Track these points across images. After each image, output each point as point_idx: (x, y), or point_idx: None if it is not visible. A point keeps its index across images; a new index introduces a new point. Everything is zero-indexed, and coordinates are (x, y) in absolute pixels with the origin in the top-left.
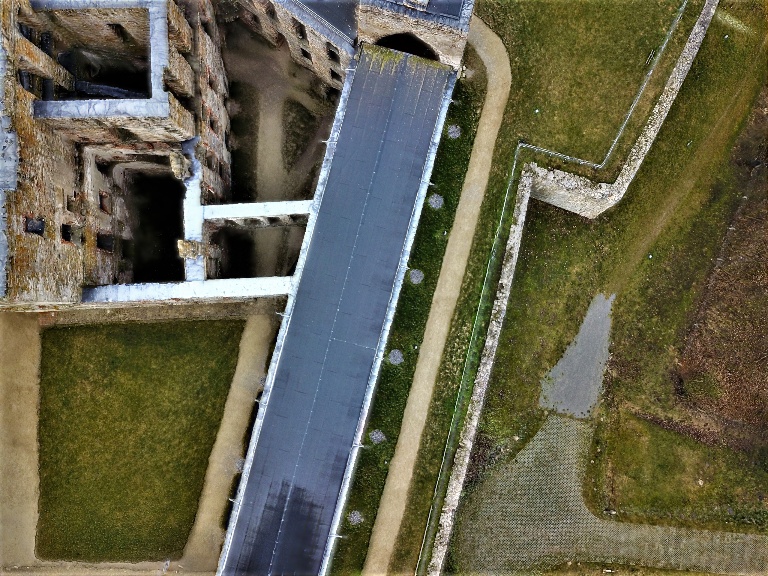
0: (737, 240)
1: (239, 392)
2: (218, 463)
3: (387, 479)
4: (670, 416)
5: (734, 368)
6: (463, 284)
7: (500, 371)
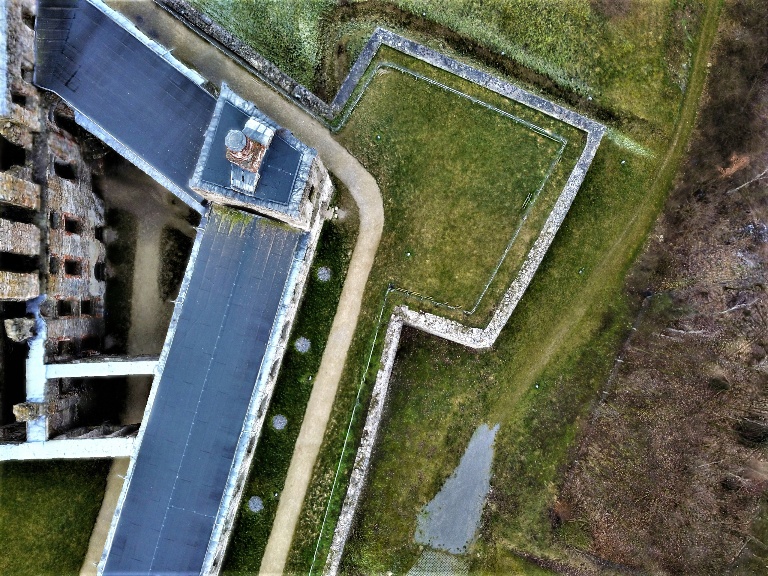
0: (624, 373)
1: (104, 527)
2: None
3: None
4: (546, 555)
5: (613, 508)
6: (327, 430)
7: (376, 504)
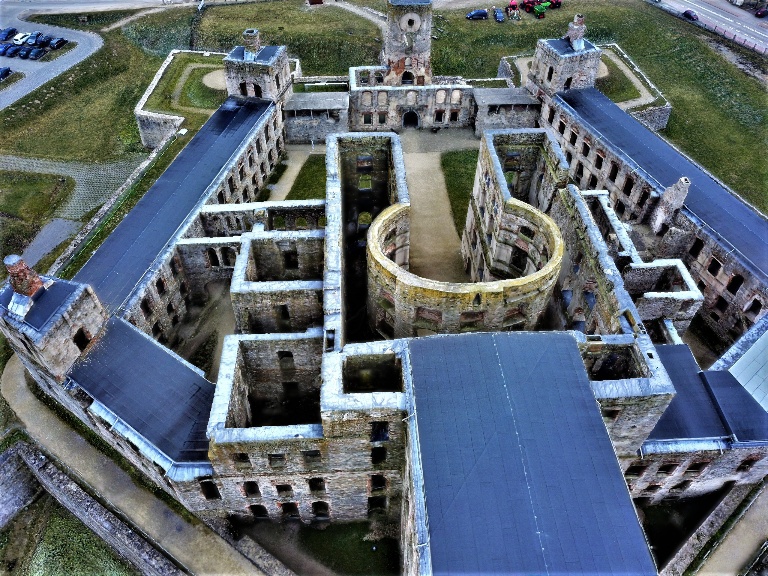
0: None
1: None
2: (286, 188)
3: None
4: (0, 217)
5: None
6: None
7: None
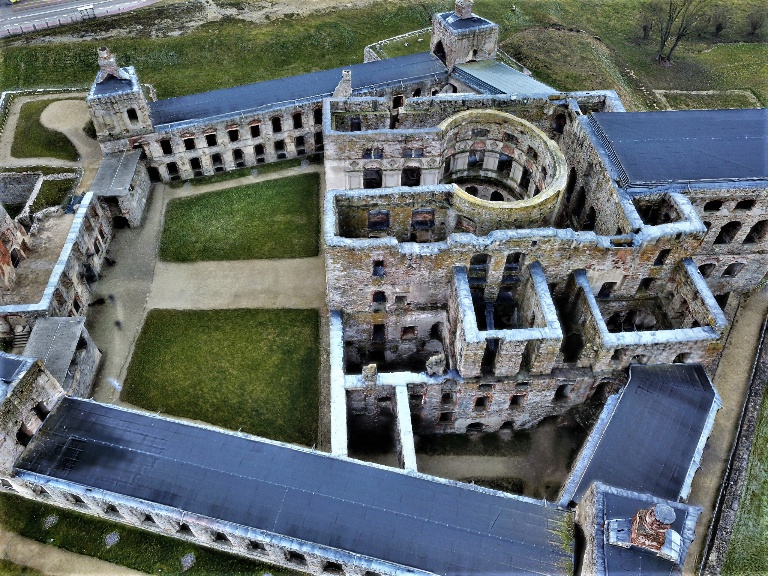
0: None
1: None
2: None
3: (143, 573)
4: None
5: None
6: None
7: None
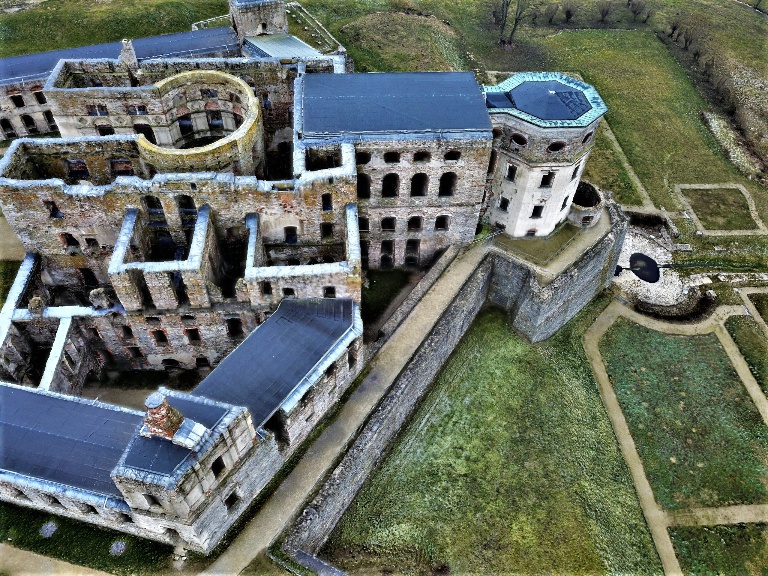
0: None
1: None
2: None
3: None
4: None
5: None
6: None
7: None
